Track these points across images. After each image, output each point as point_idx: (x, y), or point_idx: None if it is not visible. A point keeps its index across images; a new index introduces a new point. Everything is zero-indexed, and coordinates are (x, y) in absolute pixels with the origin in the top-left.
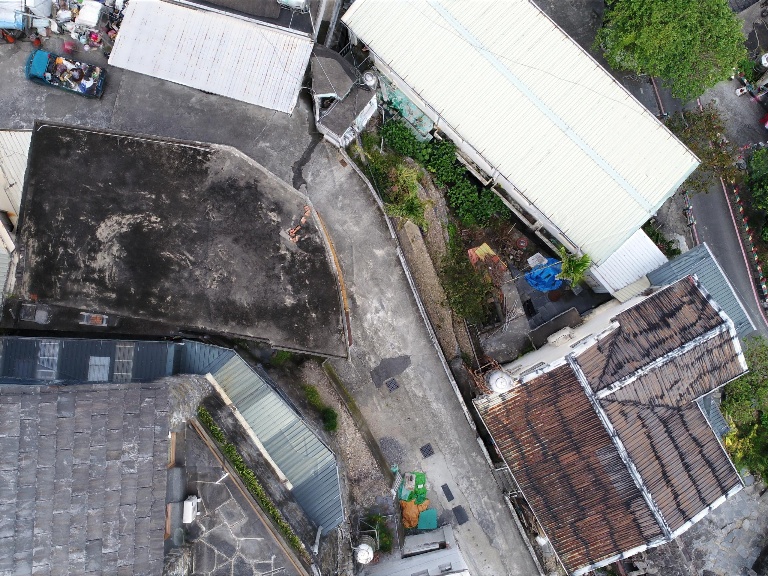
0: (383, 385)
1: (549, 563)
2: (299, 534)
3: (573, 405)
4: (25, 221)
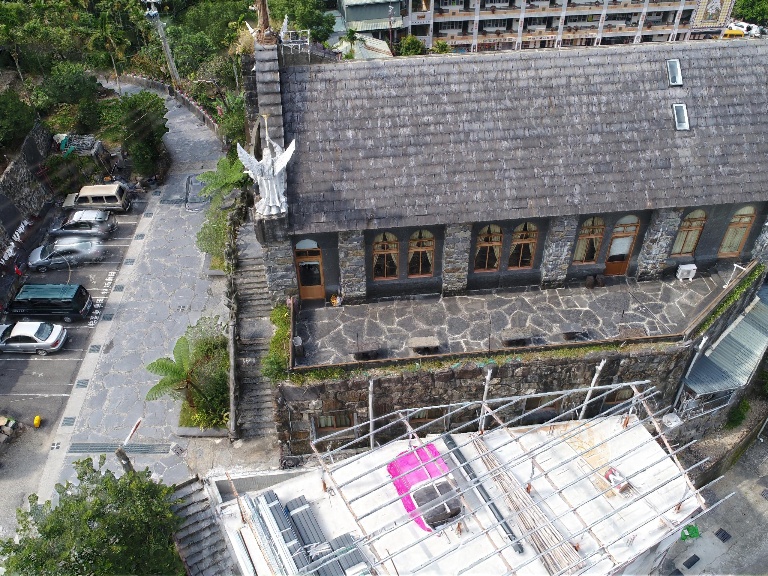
0: (762, 487)
1: None
2: (705, 334)
3: None
4: None
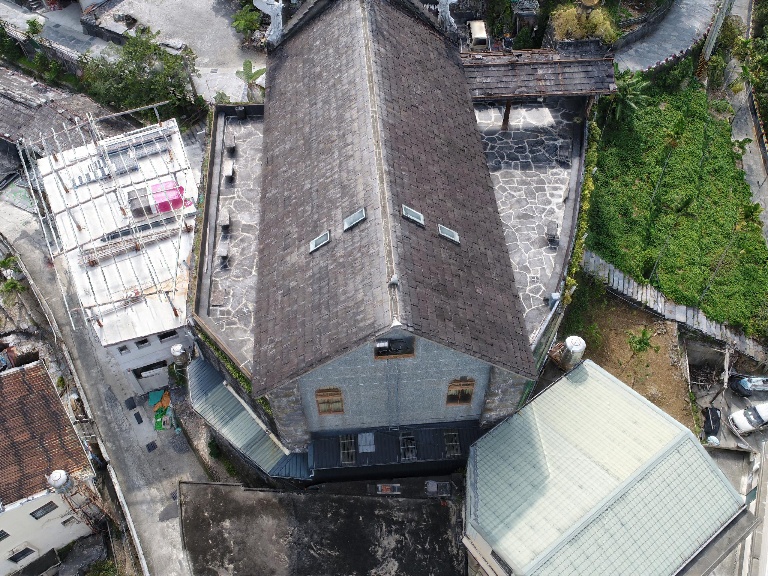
0: None
1: (74, 384)
2: None
3: (8, 474)
4: (464, 569)
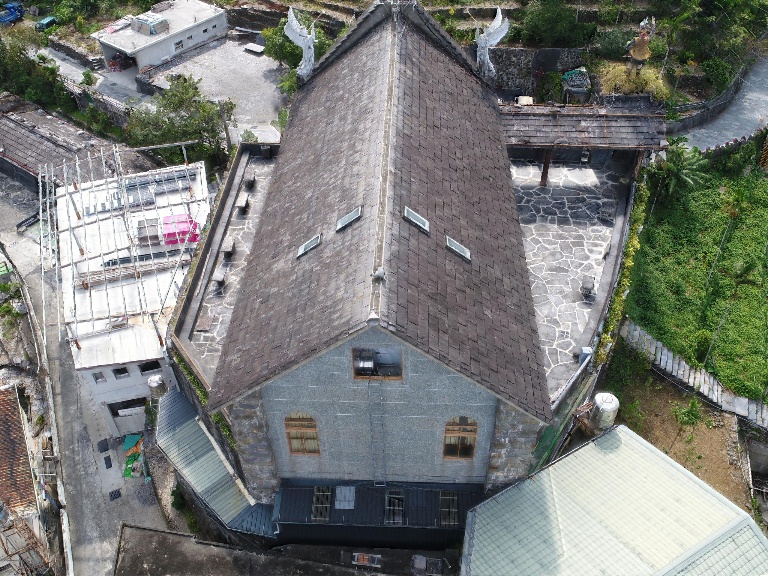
0: None
1: None
2: None
3: None
4: None
